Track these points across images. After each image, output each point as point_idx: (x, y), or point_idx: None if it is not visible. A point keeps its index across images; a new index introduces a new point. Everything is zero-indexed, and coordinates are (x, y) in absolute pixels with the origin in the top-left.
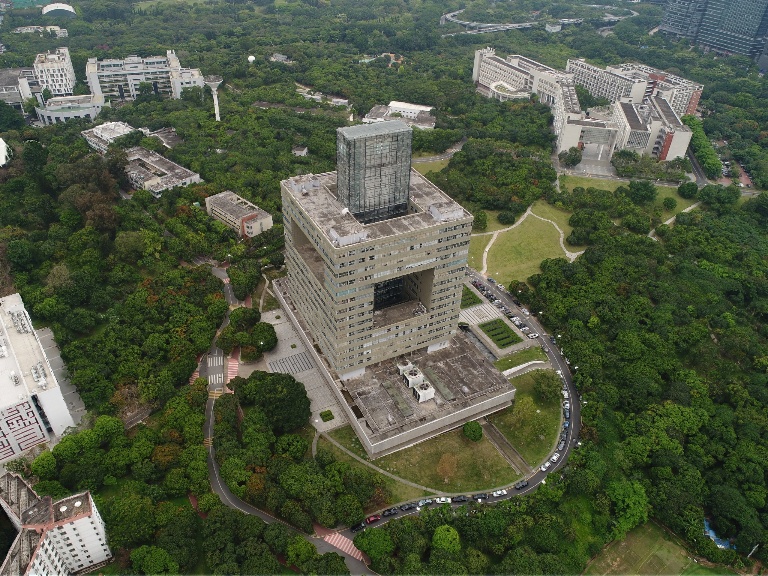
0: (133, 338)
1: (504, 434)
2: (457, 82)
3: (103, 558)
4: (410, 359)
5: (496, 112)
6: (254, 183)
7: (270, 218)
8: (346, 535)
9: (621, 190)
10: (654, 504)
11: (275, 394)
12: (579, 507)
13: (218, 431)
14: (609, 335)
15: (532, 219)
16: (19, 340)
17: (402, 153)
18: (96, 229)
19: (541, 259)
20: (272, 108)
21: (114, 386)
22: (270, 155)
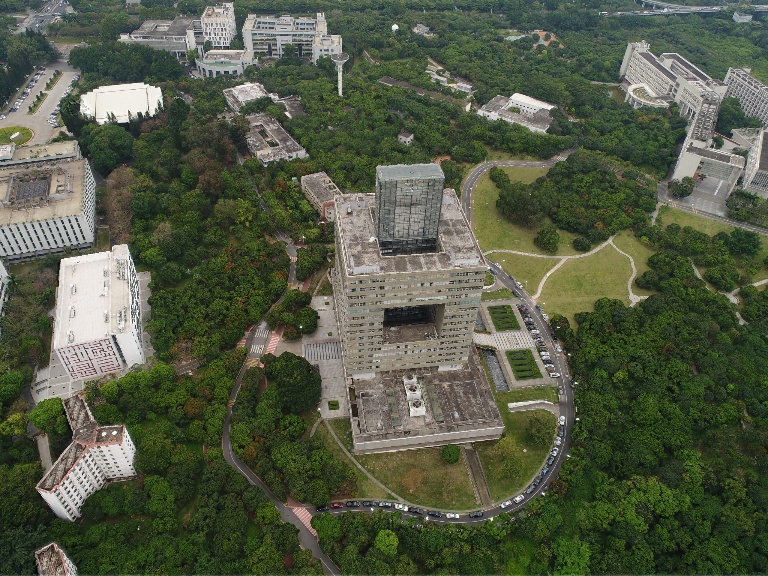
0: (203, 299)
1: (482, 463)
2: (589, 82)
3: (130, 474)
4: (420, 373)
5: (619, 122)
6: (349, 167)
7: None
8: (311, 512)
9: (721, 236)
10: (593, 570)
11: (291, 378)
12: (521, 550)
13: (240, 397)
14: (631, 393)
15: (610, 250)
16: (117, 285)
17: (433, 196)
18: (203, 192)
19: (600, 296)
20: (394, 87)
21: (176, 338)
22: (374, 139)
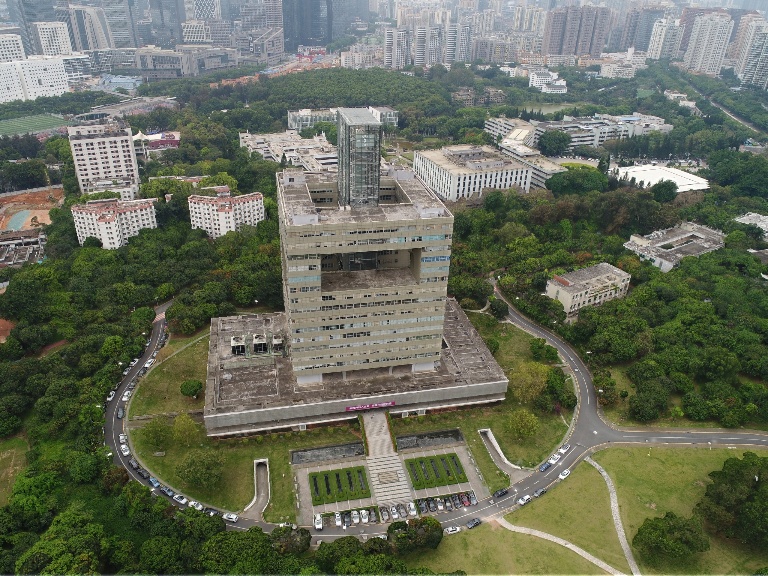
0: None
1: None
2: None
3: None
4: None
5: None
6: (663, 293)
7: (569, 295)
8: None
9: None
10: None
11: (281, 273)
12: None
13: None
14: None
15: None
16: None
17: None
18: None
19: None
20: None
21: None
22: (766, 311)
